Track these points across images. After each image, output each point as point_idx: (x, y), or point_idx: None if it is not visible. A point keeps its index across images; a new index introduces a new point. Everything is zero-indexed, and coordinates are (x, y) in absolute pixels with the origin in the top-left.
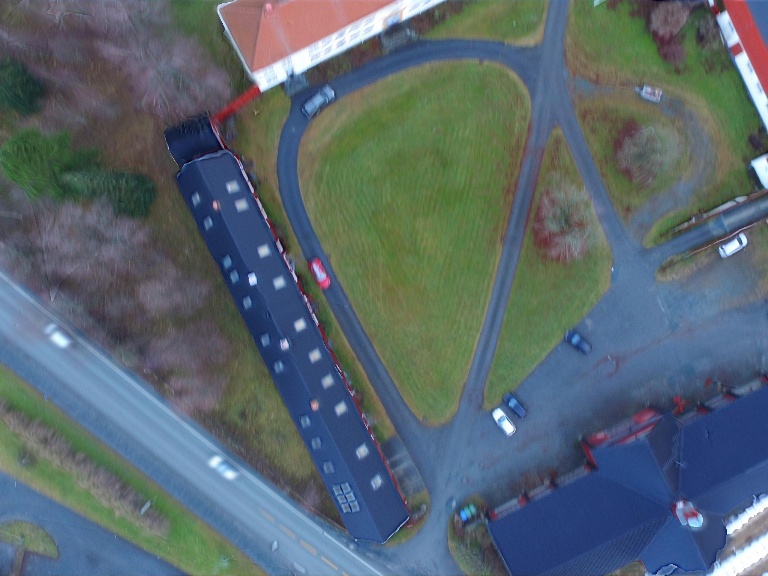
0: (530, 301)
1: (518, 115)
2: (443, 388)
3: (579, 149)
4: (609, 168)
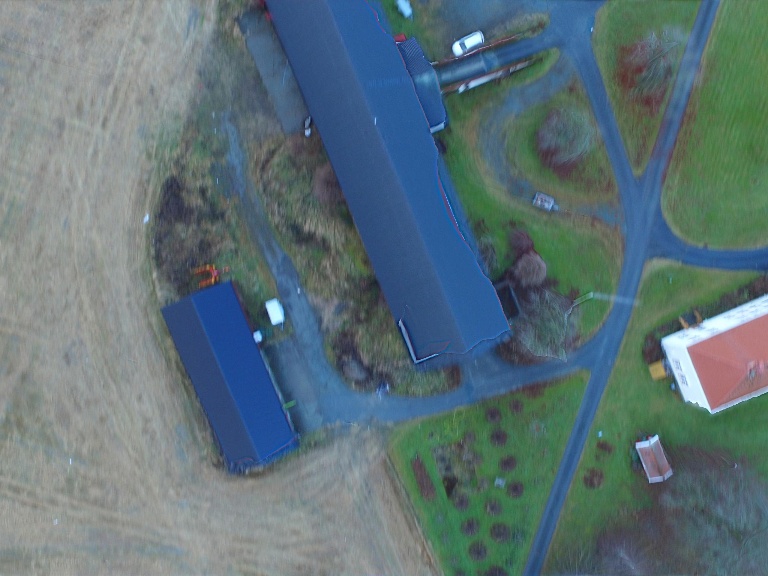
0: (679, 4)
1: (675, 191)
2: None
3: (618, 153)
4: None
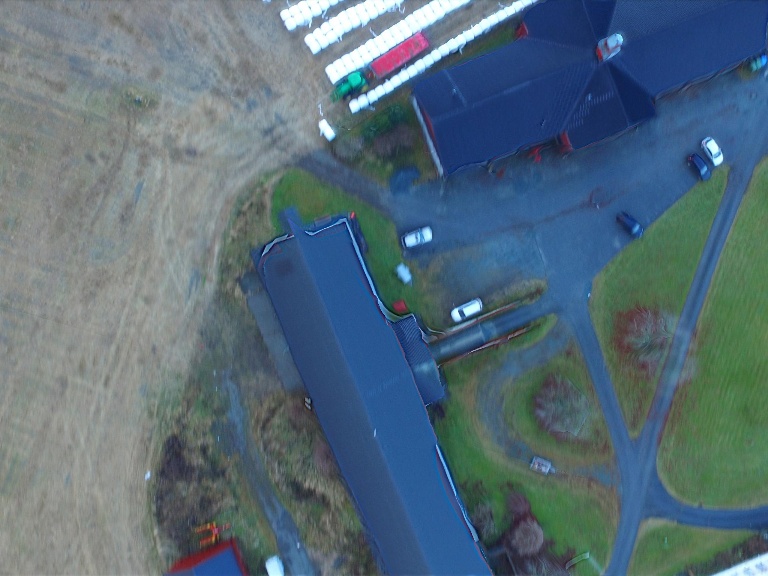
0: (675, 270)
1: (671, 453)
2: (767, 191)
3: (614, 416)
4: (586, 395)
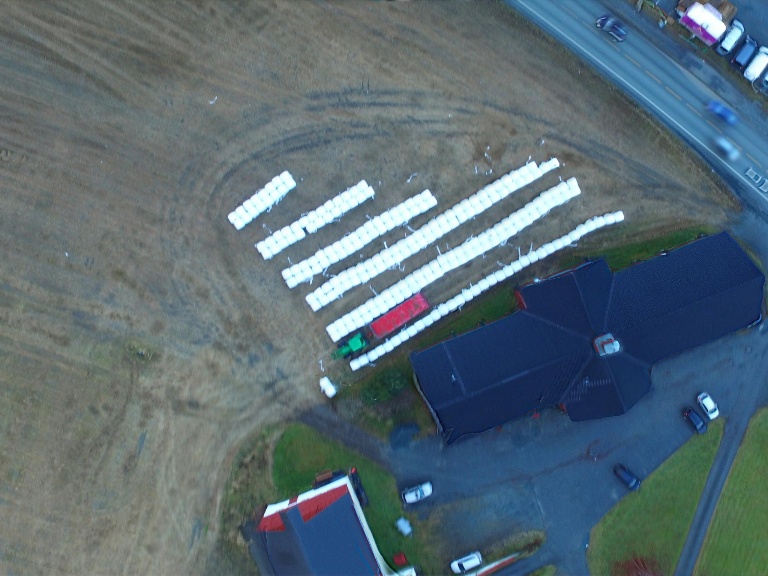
0: (672, 521)
1: None
2: (762, 442)
3: None
4: None
